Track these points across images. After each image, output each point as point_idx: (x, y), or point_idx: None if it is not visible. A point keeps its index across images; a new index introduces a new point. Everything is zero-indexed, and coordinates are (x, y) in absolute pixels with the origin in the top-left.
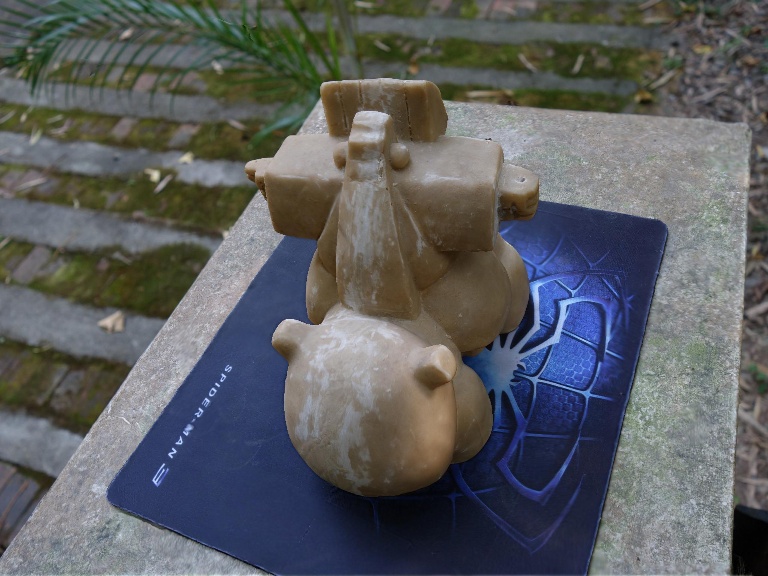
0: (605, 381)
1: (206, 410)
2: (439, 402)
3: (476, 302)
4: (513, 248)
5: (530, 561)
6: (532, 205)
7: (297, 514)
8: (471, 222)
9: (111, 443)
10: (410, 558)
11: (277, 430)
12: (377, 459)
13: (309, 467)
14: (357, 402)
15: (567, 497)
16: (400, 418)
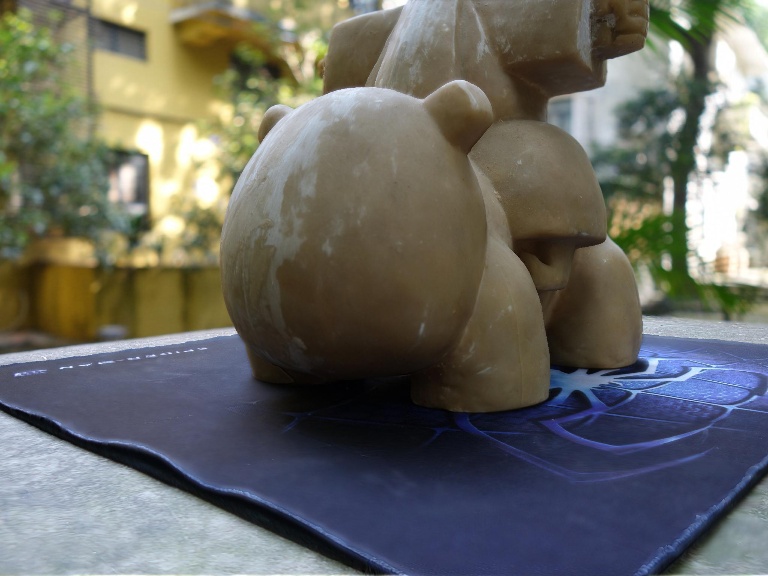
0: (766, 404)
1: (144, 358)
2: (452, 167)
3: (546, 151)
4: None
5: (567, 486)
6: (637, 14)
7: (170, 409)
8: (551, 11)
9: (8, 362)
10: (316, 453)
11: (216, 372)
12: (324, 194)
13: (230, 391)
14: (328, 110)
15: (674, 455)
16: (382, 135)
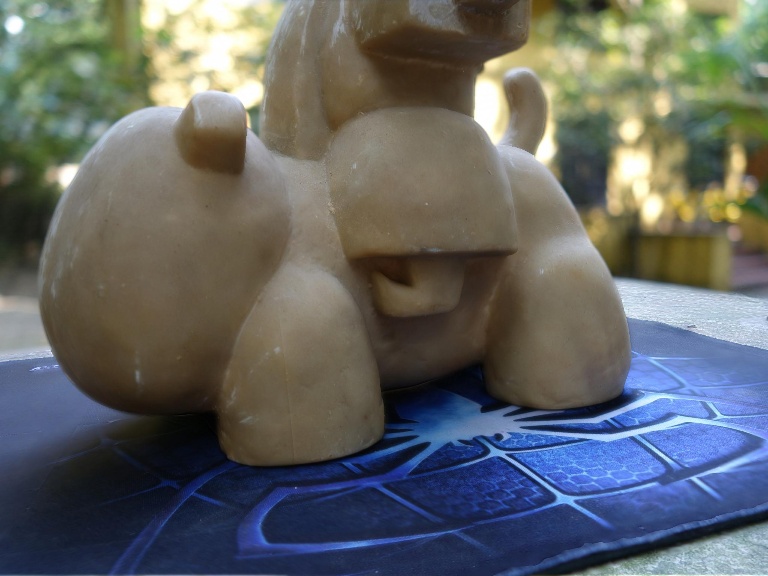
0: (630, 502)
1: None
2: (188, 194)
3: (385, 149)
4: (596, 251)
5: None
6: None
7: (41, 422)
8: None
9: None
10: (5, 497)
11: None
12: (60, 235)
13: None
14: None
15: (290, 573)
16: (111, 167)
